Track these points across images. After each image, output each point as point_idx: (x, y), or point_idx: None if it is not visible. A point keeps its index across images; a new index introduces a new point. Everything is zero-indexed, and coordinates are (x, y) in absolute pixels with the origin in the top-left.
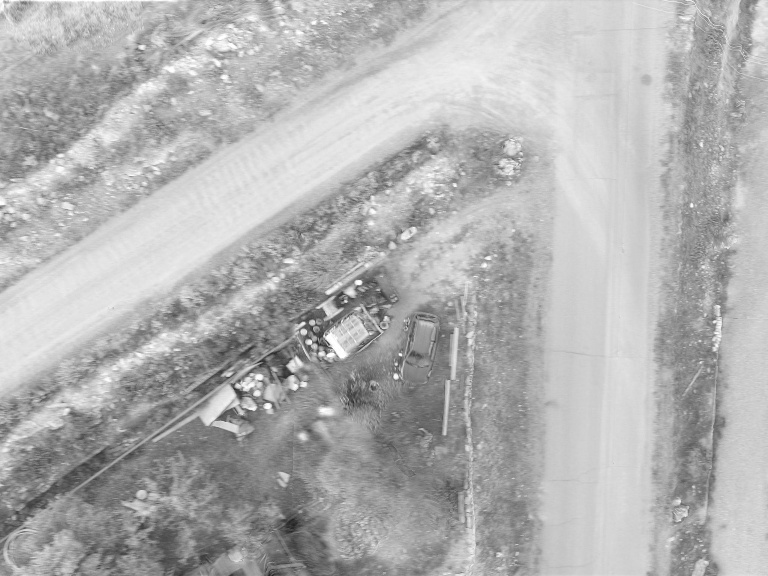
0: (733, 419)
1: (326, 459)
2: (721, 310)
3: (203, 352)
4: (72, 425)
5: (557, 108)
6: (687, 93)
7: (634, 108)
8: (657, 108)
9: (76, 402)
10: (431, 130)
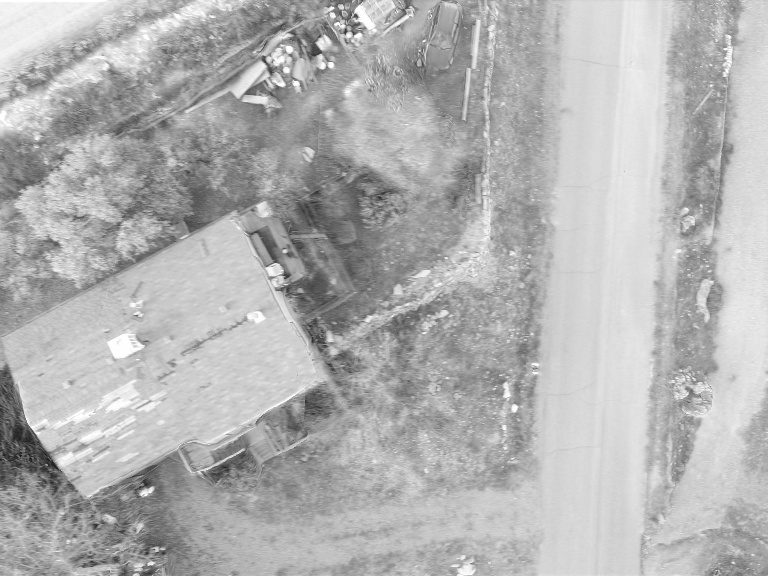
0: (741, 147)
1: (350, 137)
2: (732, 41)
3: (237, 18)
4: (110, 81)
5: None
6: None
7: None
8: None
9: (115, 58)
10: None
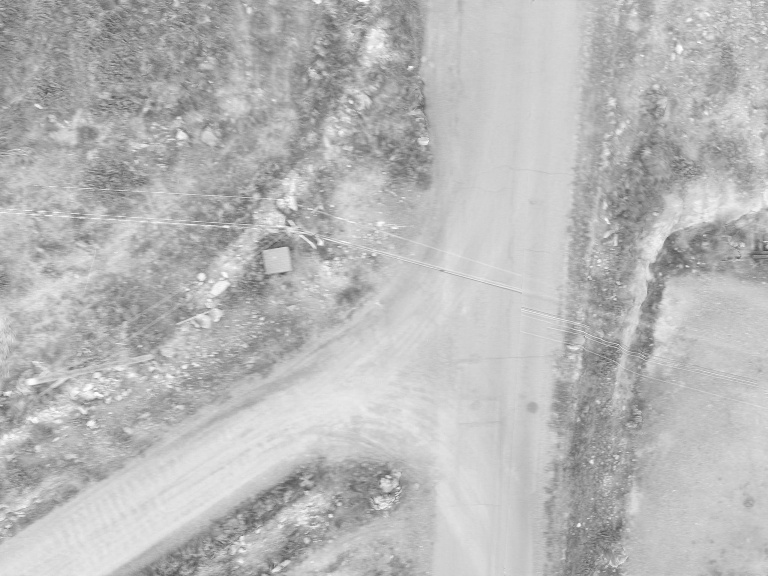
0: None
1: None
2: None
3: None
4: None
5: (439, 435)
6: (575, 419)
7: (519, 435)
8: (543, 436)
9: None
10: (306, 464)
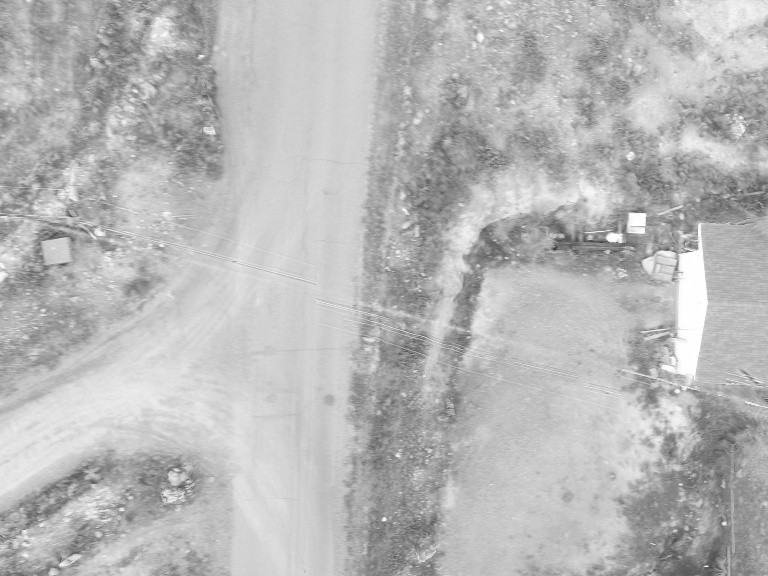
0: None
1: None
2: None
3: None
4: None
5: (235, 428)
6: (374, 412)
7: (316, 428)
8: (340, 429)
9: None
10: (94, 457)
